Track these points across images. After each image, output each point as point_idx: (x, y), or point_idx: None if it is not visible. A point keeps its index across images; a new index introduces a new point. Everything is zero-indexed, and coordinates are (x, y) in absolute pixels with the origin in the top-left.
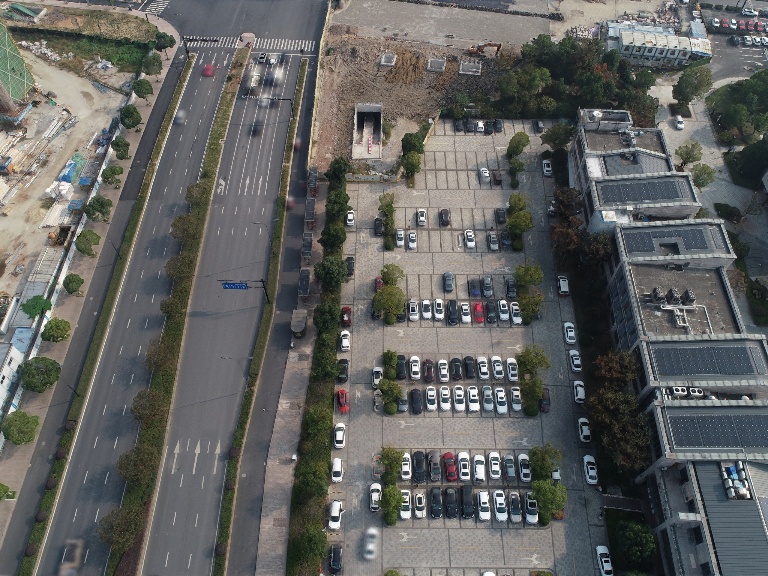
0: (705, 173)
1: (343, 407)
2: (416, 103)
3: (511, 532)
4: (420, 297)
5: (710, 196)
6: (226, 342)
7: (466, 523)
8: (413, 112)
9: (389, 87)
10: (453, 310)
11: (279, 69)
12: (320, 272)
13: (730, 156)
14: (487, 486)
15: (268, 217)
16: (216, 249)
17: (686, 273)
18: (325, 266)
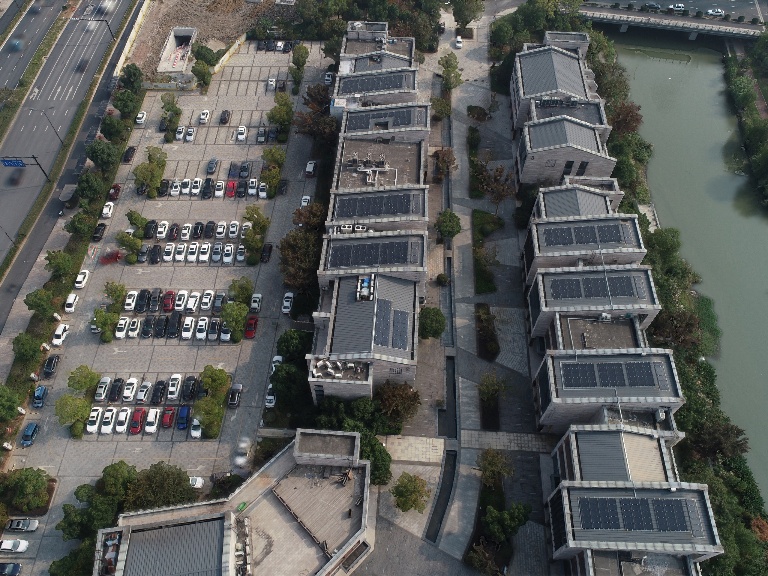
0: (454, 77)
1: (90, 258)
2: (229, 28)
3: (207, 348)
4: (185, 178)
5: (467, 100)
6: (5, 212)
7: (171, 341)
8: (224, 35)
9: (208, 15)
10: (207, 186)
11: (113, 1)
12: (88, 151)
13: (495, 69)
14: (197, 315)
15: (69, 117)
16: (16, 142)
17: (391, 145)
18: (92, 146)
